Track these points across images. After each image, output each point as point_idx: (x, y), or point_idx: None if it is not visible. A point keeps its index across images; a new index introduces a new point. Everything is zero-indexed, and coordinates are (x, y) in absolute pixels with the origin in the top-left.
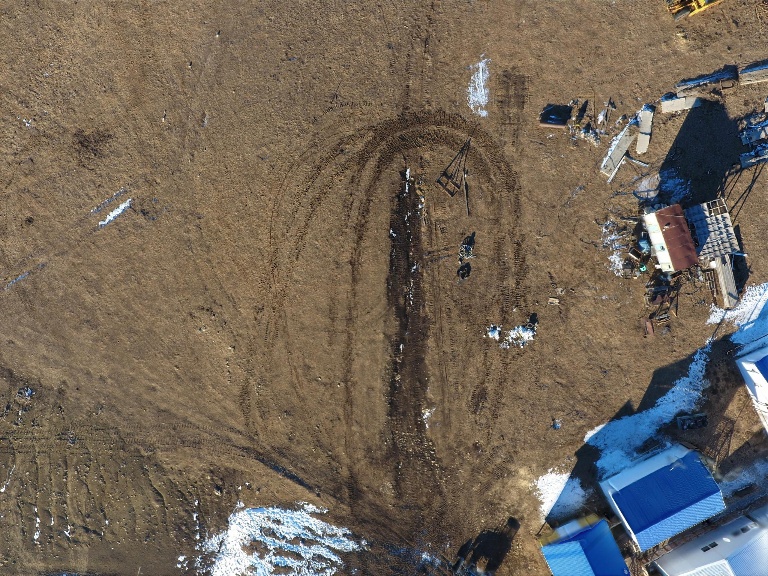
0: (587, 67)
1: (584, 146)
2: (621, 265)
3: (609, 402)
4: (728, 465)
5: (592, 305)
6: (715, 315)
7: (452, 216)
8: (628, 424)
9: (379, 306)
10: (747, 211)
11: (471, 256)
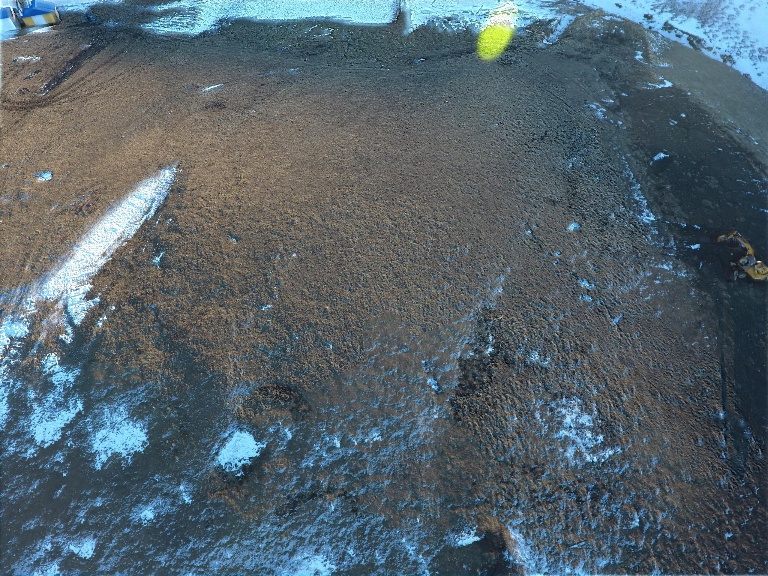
0: None
1: None
2: None
3: None
4: None
5: None
6: None
7: None
8: None
9: None
10: None
11: None
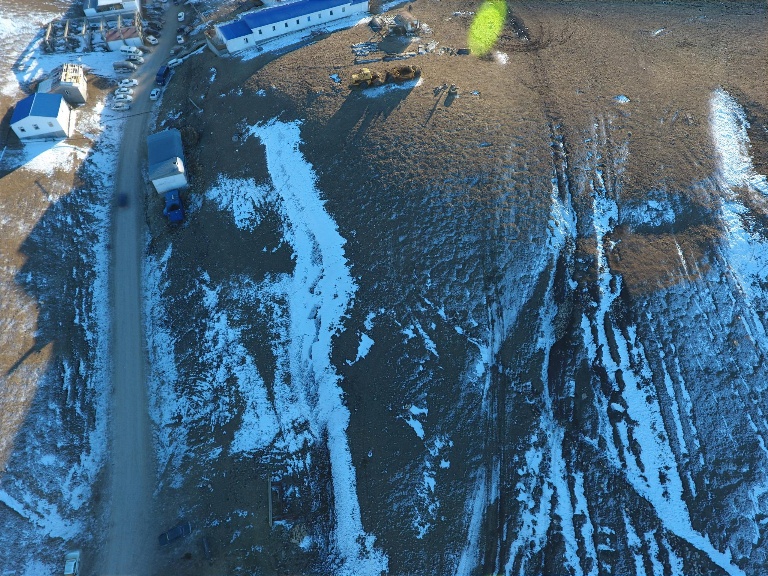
0: None
1: None
2: None
3: (420, 2)
4: None
5: None
6: None
7: None
8: None
9: None
10: None
11: None
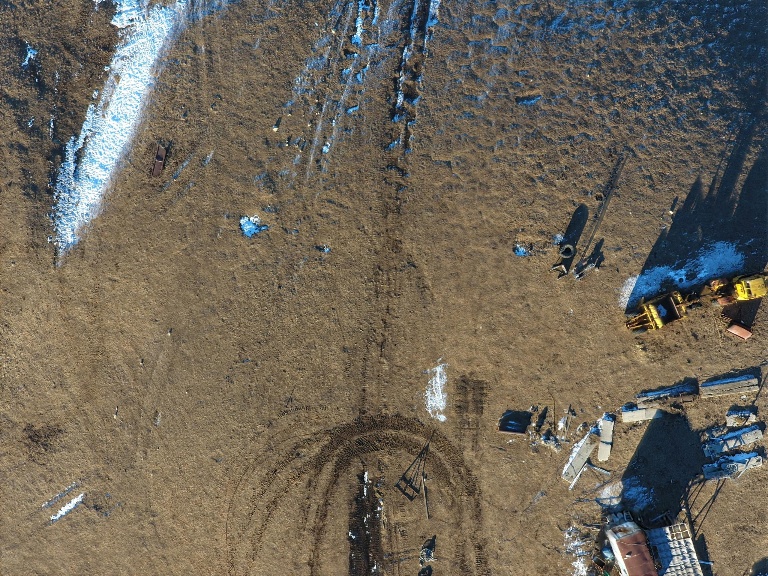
0: (546, 374)
1: (545, 452)
2: (585, 571)
3: None
4: None
5: None
6: None
7: (412, 519)
8: None
9: None
10: (711, 520)
11: (432, 559)
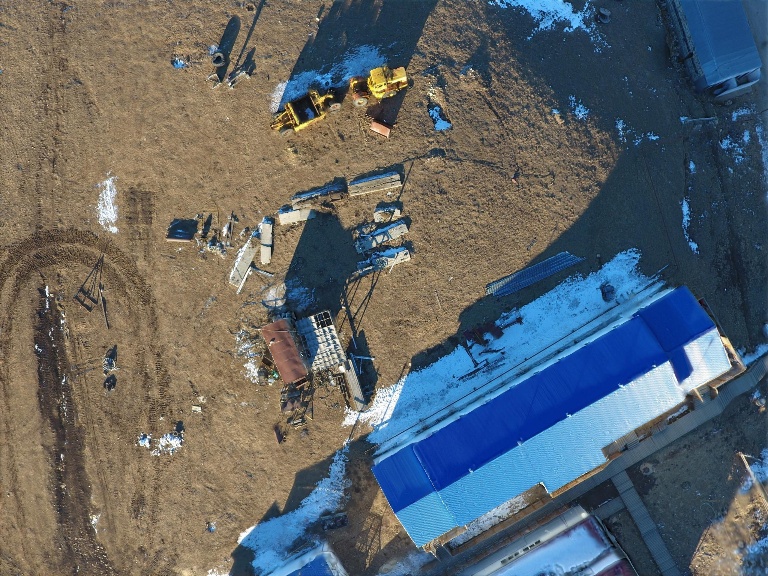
0: (208, 182)
1: (212, 258)
2: (256, 372)
3: (256, 505)
4: (381, 558)
5: (233, 412)
6: (349, 417)
7: (93, 330)
8: (276, 525)
9: (34, 419)
10: (369, 316)
11: (115, 368)
